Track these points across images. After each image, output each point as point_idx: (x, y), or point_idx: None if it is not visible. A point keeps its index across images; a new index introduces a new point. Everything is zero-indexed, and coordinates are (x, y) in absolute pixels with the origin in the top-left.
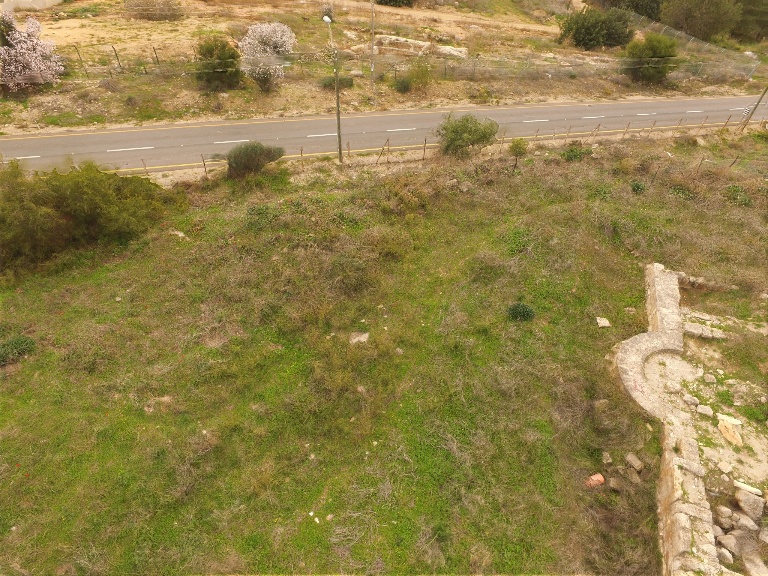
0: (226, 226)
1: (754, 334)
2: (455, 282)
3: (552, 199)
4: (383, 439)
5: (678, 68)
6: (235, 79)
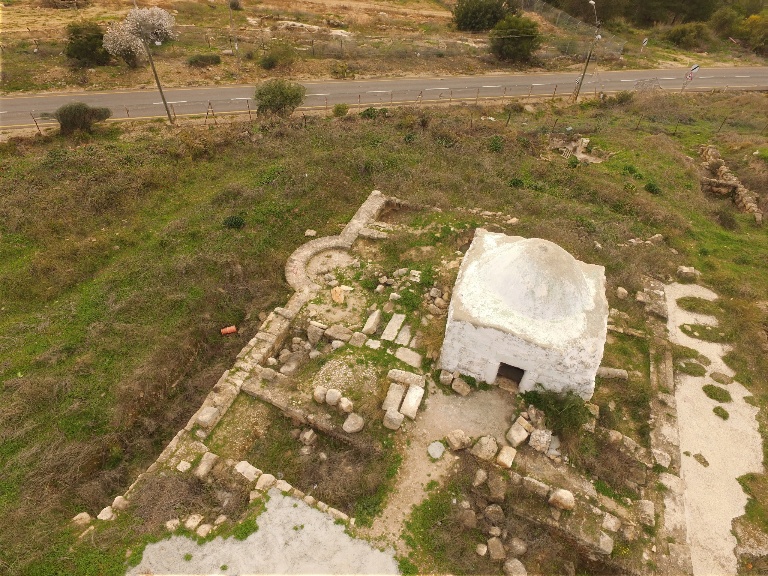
0: (28, 166)
1: (402, 233)
2: (197, 204)
3: (327, 147)
4: (65, 299)
5: (539, 46)
6: (105, 56)
